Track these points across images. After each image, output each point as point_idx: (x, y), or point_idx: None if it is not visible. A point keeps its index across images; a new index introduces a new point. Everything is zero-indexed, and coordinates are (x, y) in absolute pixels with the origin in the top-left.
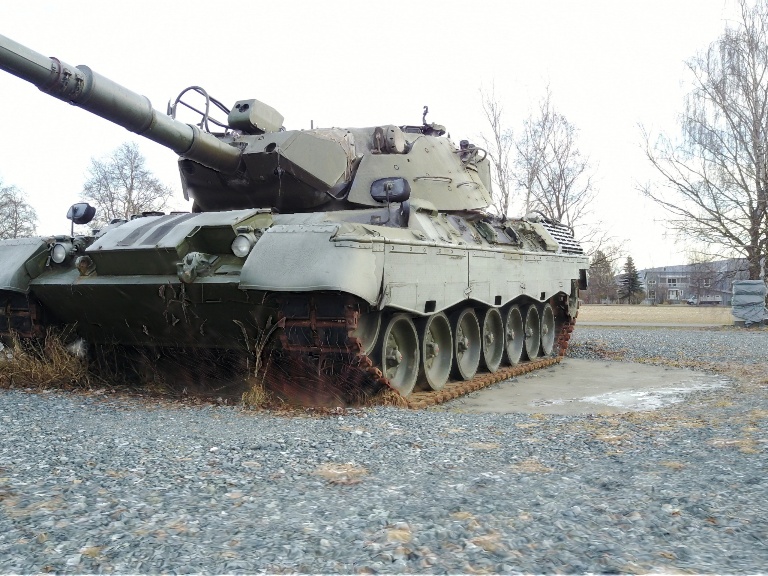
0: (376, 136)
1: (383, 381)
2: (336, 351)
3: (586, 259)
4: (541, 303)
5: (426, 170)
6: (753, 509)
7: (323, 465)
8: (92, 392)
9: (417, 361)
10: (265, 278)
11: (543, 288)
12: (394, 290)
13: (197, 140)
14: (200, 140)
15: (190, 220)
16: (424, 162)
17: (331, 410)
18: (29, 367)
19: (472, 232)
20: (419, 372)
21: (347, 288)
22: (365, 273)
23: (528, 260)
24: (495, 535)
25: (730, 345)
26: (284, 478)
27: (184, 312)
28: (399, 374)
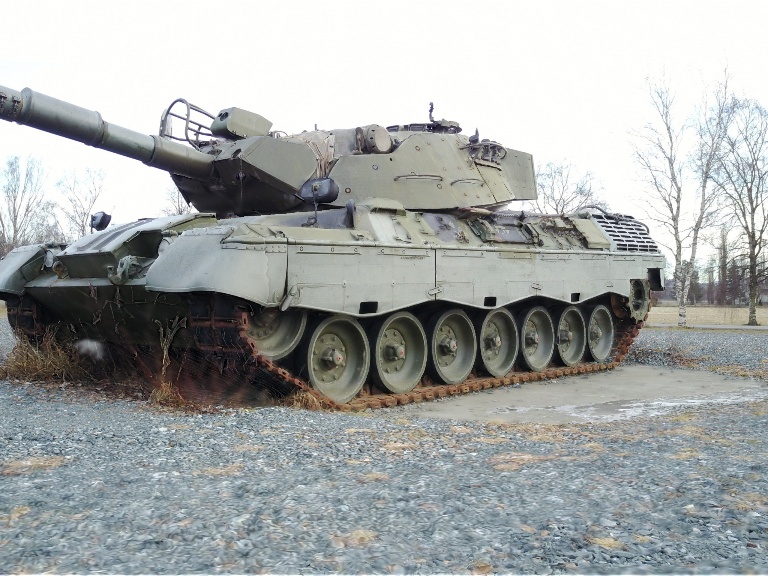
0: (357, 137)
1: (293, 381)
2: (234, 351)
3: (660, 257)
4: (593, 305)
5: (412, 168)
6: (332, 525)
7: (41, 457)
8: (58, 385)
9: (366, 363)
10: (162, 280)
11: (575, 289)
12: (305, 291)
13: (158, 150)
14: (162, 150)
15: (141, 226)
16: (411, 160)
17: (205, 408)
18: (22, 361)
19: None
20: (373, 374)
21: (223, 289)
22: (253, 274)
23: (546, 259)
24: (0, 529)
25: None
26: None
27: (112, 312)
28: (346, 375)
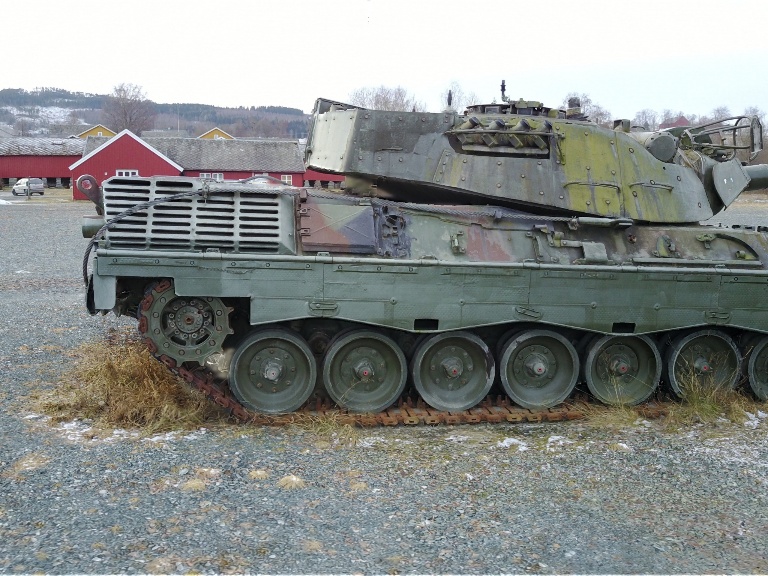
0: None
1: None
2: None
3: None
4: None
5: None
6: None
7: None
8: None
9: None
10: None
11: None
12: None
13: None
14: None
15: None
16: None
17: None
18: None
19: None
20: None
21: None
22: None
23: None
24: None
25: (71, 305)
26: None
27: None
28: None
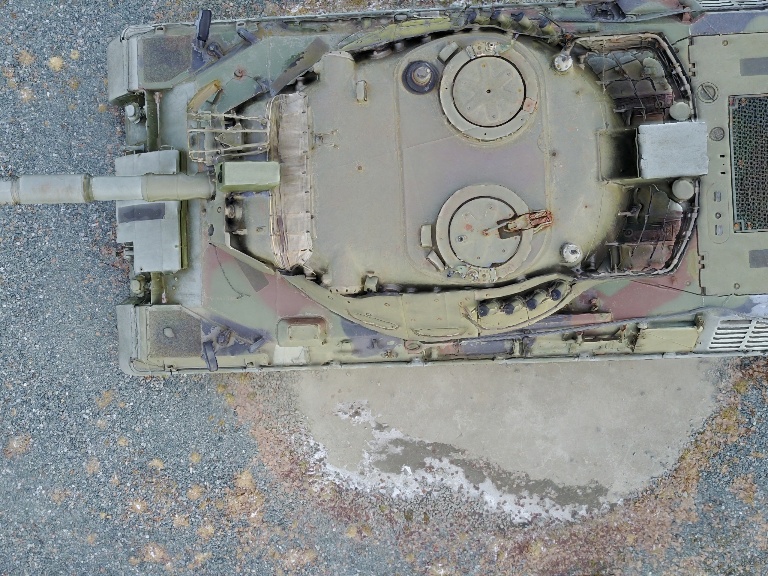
0: None
1: None
2: None
3: None
4: None
5: (370, 312)
6: (44, 567)
7: (24, 434)
8: None
9: None
10: (118, 323)
11: None
12: None
13: None
14: None
15: (144, 224)
16: (373, 308)
17: None
18: None
19: (399, 347)
20: None
21: None
22: None
23: None
24: None
25: None
26: (0, 435)
27: None
28: None
